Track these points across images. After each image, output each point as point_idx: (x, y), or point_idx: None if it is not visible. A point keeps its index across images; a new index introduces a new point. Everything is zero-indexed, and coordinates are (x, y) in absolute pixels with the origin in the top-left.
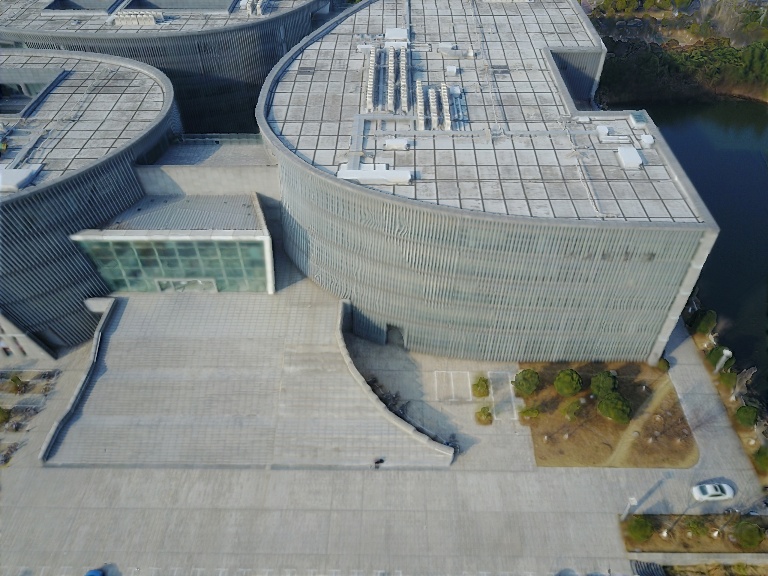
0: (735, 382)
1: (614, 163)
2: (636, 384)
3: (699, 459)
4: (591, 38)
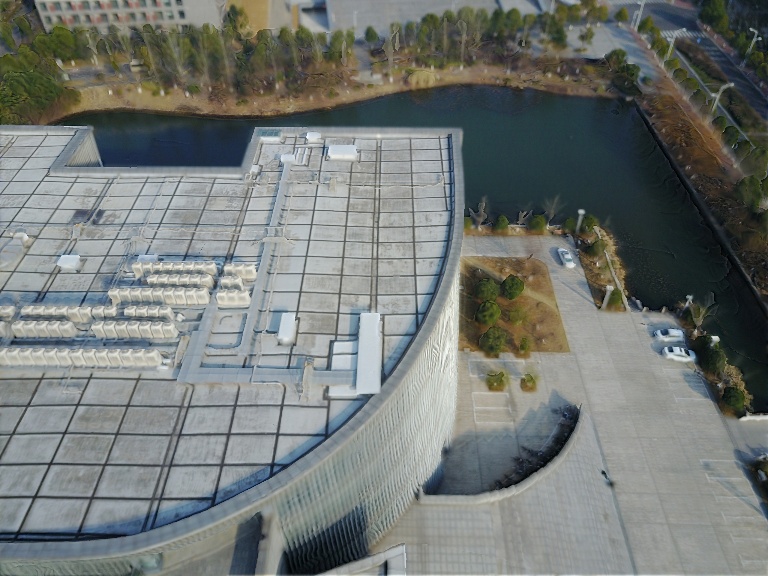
0: (472, 220)
1: (348, 164)
2: (472, 276)
3: (537, 259)
4: (42, 134)
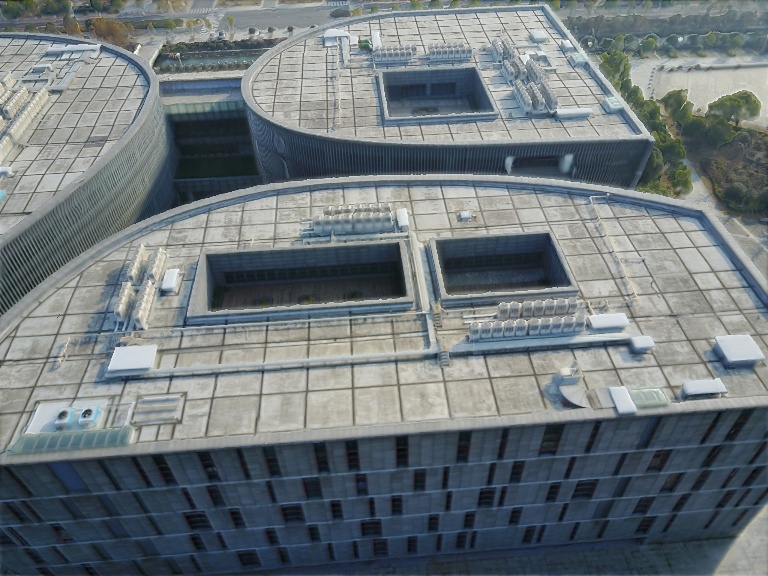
0: None
1: None
2: None
3: None
4: None
